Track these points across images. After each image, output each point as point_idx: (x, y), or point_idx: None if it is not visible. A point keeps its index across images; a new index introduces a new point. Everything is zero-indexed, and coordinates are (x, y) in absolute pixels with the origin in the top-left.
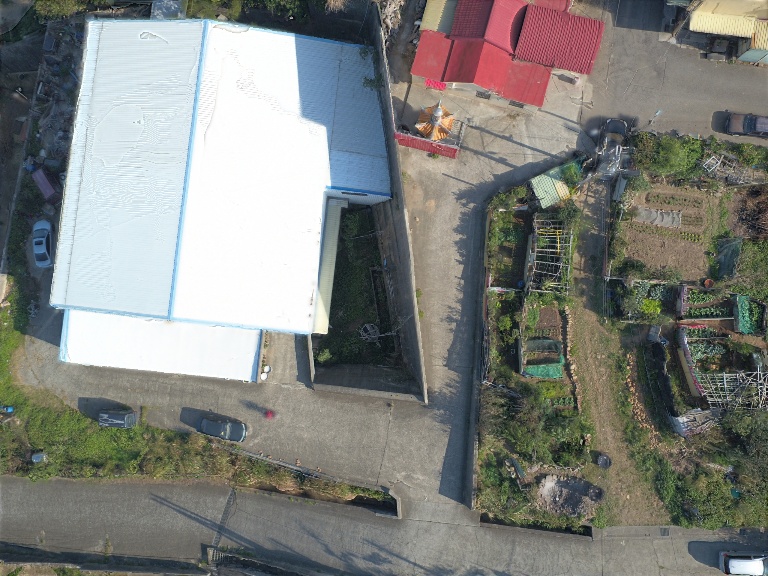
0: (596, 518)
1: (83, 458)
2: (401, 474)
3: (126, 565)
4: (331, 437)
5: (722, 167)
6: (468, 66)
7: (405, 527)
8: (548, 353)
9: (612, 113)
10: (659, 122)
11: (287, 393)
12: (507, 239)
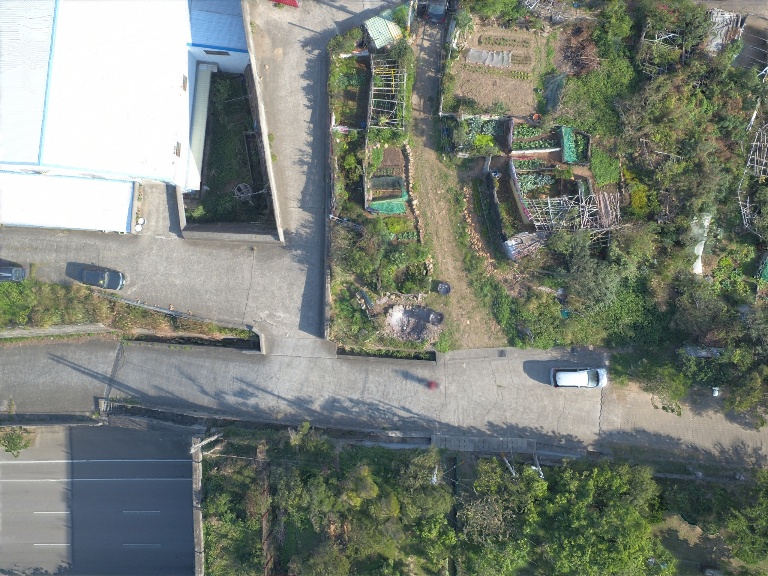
0: (438, 342)
1: None
2: (264, 313)
3: (28, 421)
4: (201, 282)
5: (542, 3)
6: None
7: (269, 363)
8: (392, 190)
9: None
10: None
11: (161, 243)
12: (350, 83)
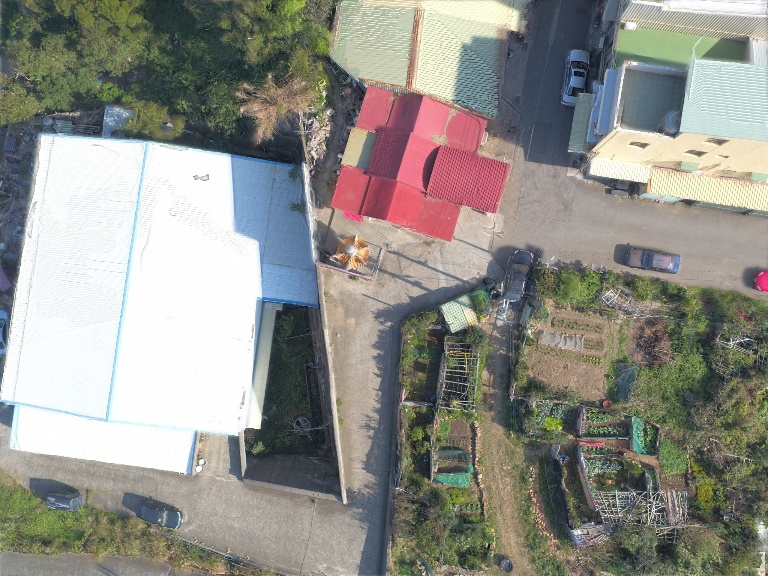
0: None
1: (33, 535)
2: (322, 566)
3: None
4: (259, 528)
5: (619, 300)
6: (382, 203)
7: None
8: (458, 462)
9: (521, 243)
10: (565, 253)
11: (220, 485)
12: (421, 356)
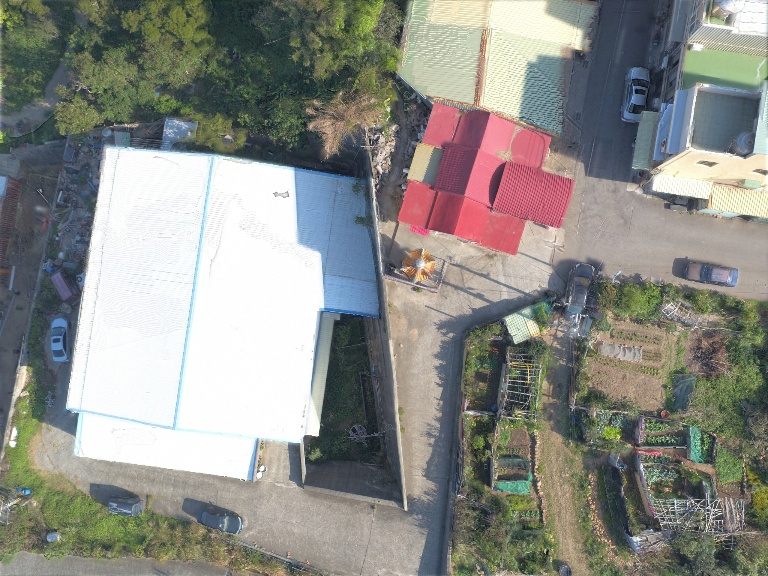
0: None
1: (93, 539)
2: (382, 570)
3: None
4: (319, 533)
5: (679, 313)
6: (450, 218)
7: None
8: (517, 470)
9: (582, 256)
10: (624, 266)
11: (280, 491)
12: (483, 366)
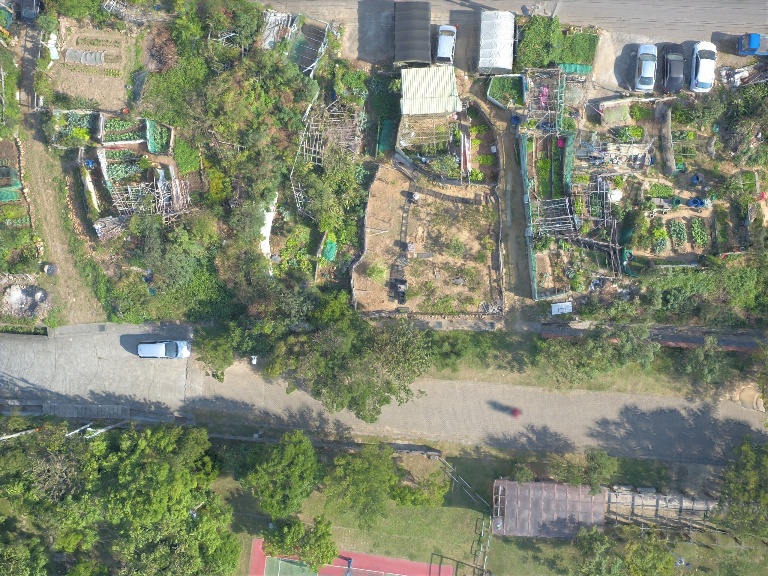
0: (46, 318)
1: None
2: None
3: None
4: None
5: (118, 7)
6: None
7: None
8: (7, 180)
9: None
10: None
11: None
12: None
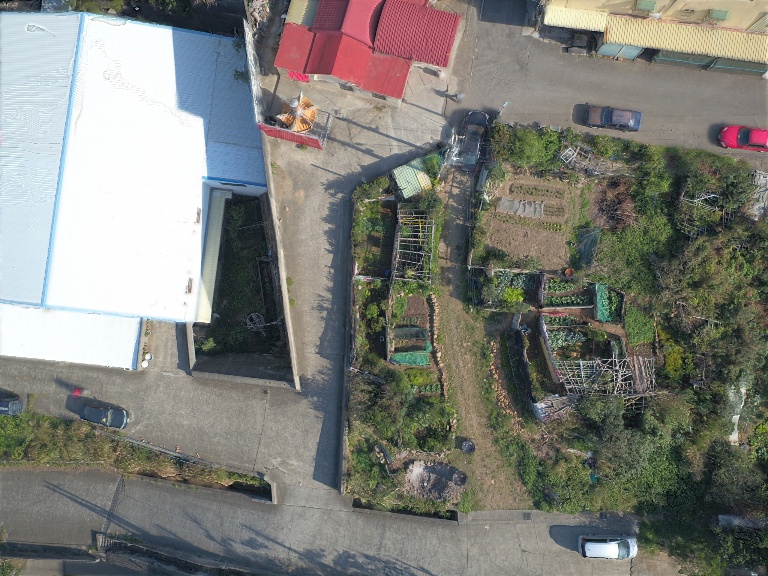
0: (461, 503)
1: None
2: (276, 460)
3: (19, 551)
4: (210, 424)
5: (578, 158)
6: (327, 58)
7: (280, 512)
8: (416, 341)
9: (476, 105)
10: (521, 114)
11: (168, 380)
12: (375, 229)
